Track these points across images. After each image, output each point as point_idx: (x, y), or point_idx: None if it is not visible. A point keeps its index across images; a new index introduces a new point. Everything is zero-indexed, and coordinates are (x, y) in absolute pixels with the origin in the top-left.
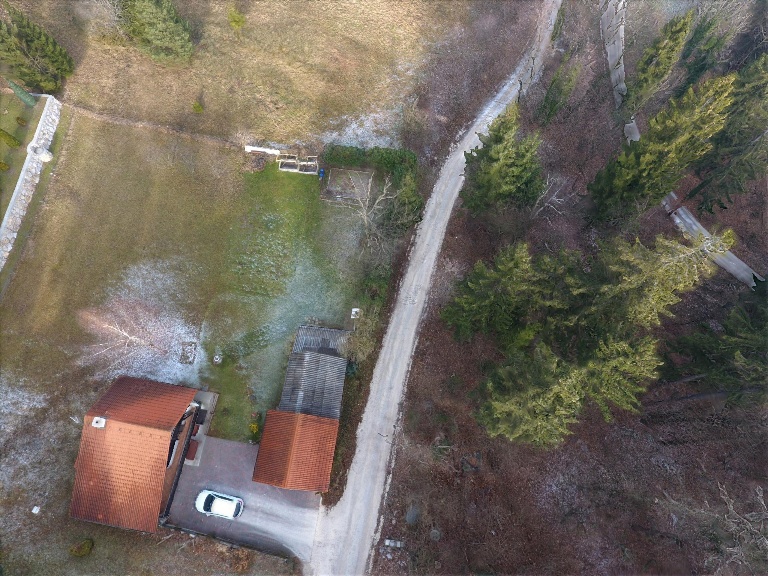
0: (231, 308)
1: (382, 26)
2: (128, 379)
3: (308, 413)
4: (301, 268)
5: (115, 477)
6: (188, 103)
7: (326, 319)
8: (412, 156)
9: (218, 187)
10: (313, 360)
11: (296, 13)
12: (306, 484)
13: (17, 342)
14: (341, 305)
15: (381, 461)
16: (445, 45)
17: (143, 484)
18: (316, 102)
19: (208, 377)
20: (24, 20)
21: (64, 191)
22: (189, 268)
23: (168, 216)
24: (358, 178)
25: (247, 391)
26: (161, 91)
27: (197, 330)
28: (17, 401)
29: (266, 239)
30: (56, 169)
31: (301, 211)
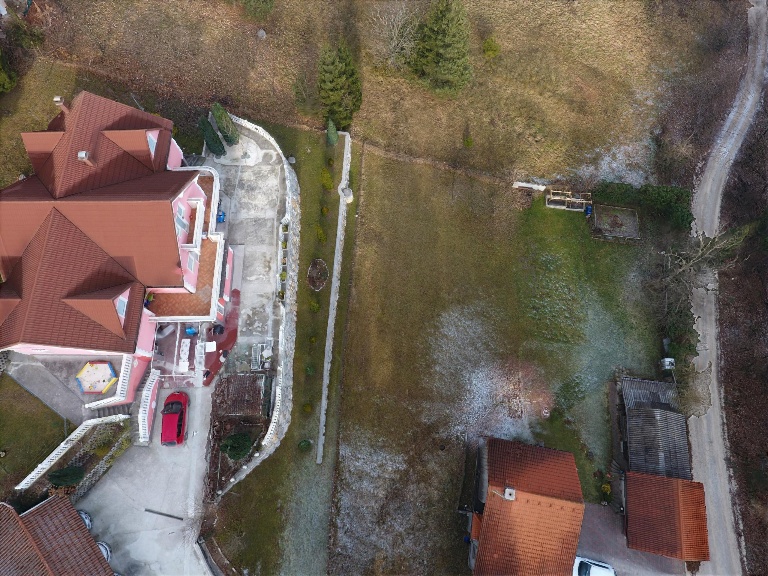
0: (539, 357)
1: (614, 52)
2: (499, 441)
3: (671, 475)
4: (592, 312)
5: (522, 550)
6: (457, 137)
7: (633, 368)
8: (688, 194)
9: (494, 226)
10: (663, 418)
11: (534, 39)
12: (695, 554)
13: (368, 399)
14: (643, 353)
15: (726, 522)
16: (676, 72)
17: (553, 558)
18: (569, 134)
19: (540, 432)
20: (349, 58)
21: (370, 234)
22: (492, 314)
23: (459, 258)
24: (623, 215)
25: (583, 447)
26: (434, 125)
27: (516, 381)
28: (382, 463)
29: (550, 281)
30: (359, 211)
31: (576, 251)
